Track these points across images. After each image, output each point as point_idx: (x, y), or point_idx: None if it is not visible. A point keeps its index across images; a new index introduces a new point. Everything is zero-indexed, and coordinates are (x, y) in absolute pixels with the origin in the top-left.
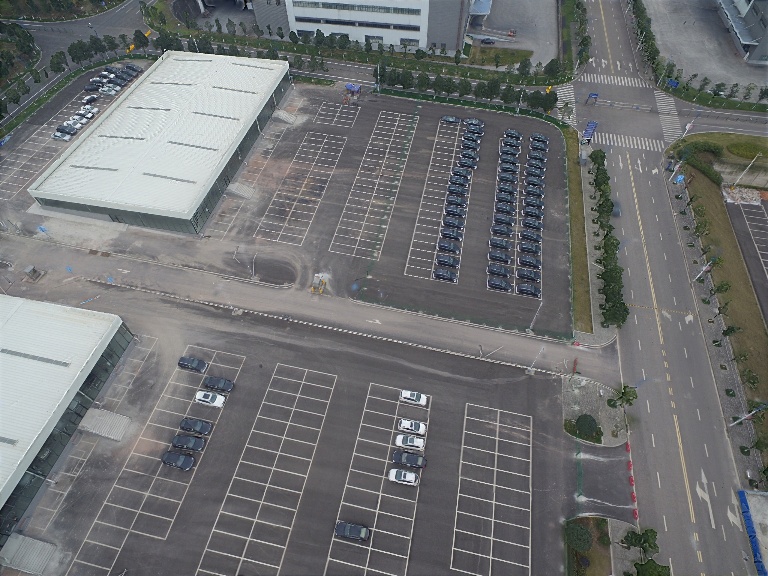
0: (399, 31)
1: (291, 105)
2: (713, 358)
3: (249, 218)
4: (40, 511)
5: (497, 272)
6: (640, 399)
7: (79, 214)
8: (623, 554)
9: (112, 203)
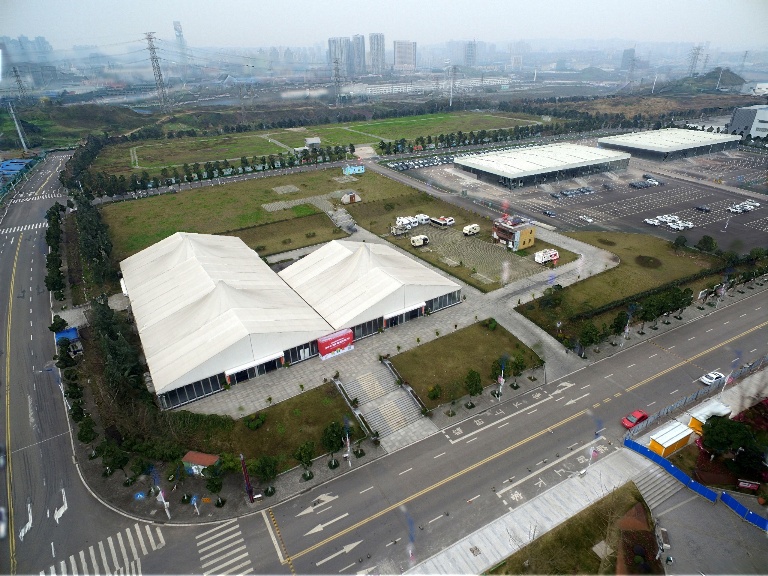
0: None
1: (732, 154)
2: None
3: (690, 166)
4: None
5: None
6: None
7: None
8: None
9: (633, 144)
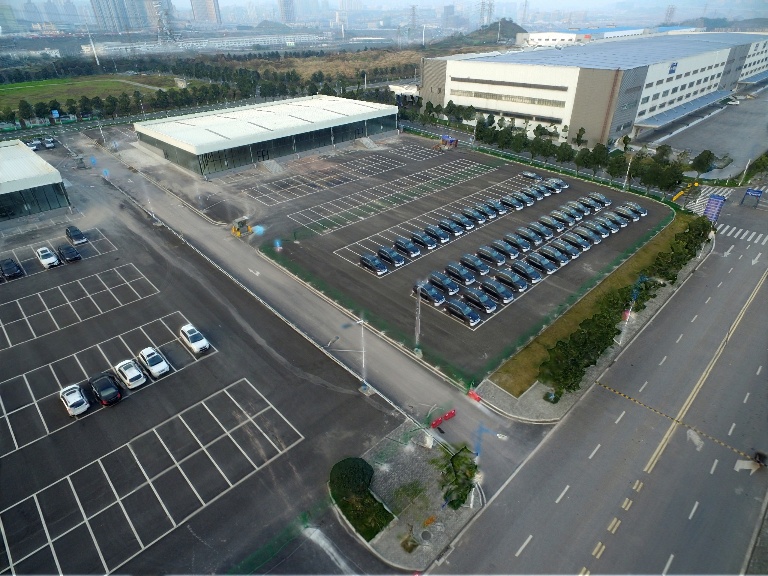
0: (540, 123)
1: (383, 141)
2: (761, 552)
3: (255, 181)
4: None
5: (437, 281)
6: (517, 524)
7: (152, 149)
8: None
9: (164, 135)
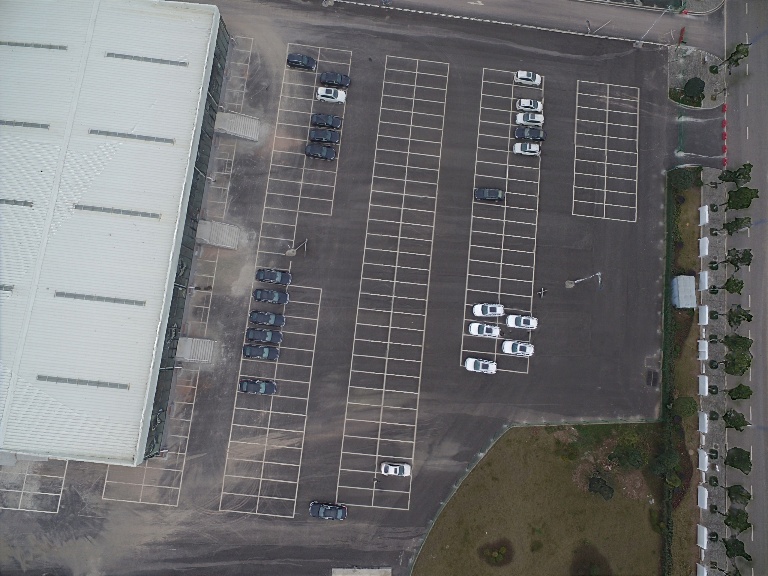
0: None
1: None
2: None
3: None
4: (212, 204)
5: None
6: (740, 63)
7: None
8: (711, 192)
9: None
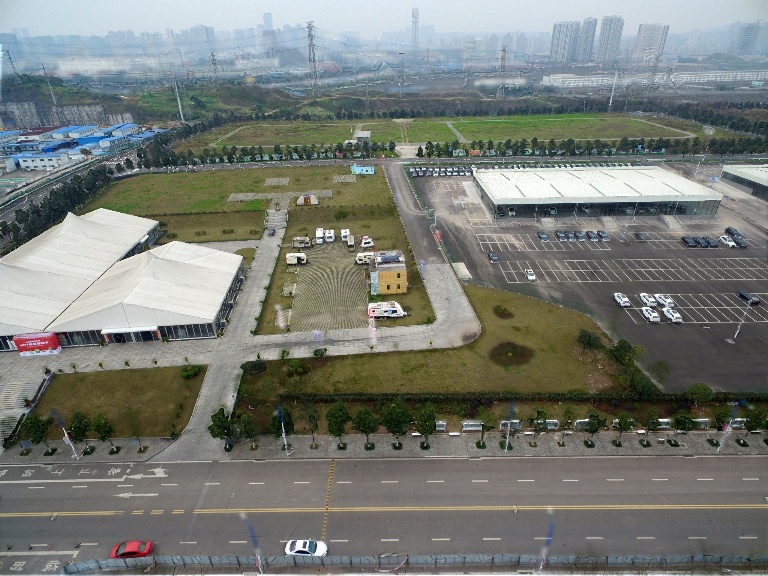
0: None
1: None
2: None
3: None
4: None
5: None
6: None
7: (736, 186)
8: None
9: (765, 180)
